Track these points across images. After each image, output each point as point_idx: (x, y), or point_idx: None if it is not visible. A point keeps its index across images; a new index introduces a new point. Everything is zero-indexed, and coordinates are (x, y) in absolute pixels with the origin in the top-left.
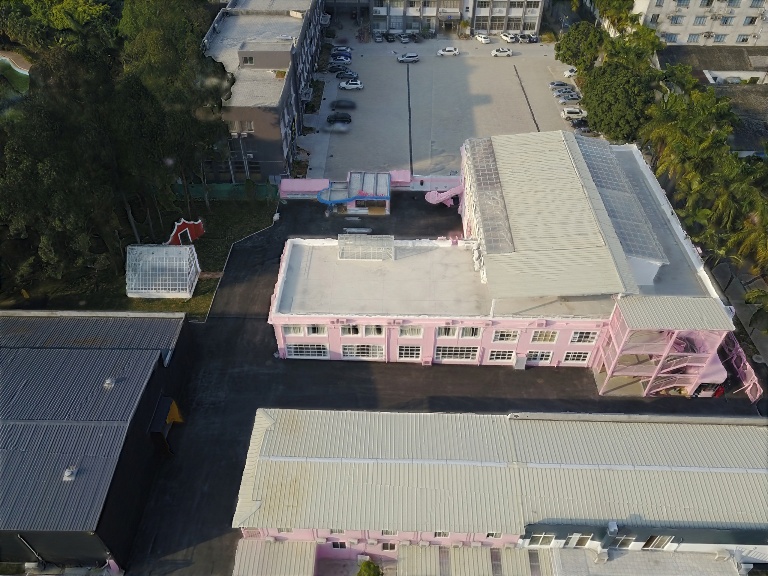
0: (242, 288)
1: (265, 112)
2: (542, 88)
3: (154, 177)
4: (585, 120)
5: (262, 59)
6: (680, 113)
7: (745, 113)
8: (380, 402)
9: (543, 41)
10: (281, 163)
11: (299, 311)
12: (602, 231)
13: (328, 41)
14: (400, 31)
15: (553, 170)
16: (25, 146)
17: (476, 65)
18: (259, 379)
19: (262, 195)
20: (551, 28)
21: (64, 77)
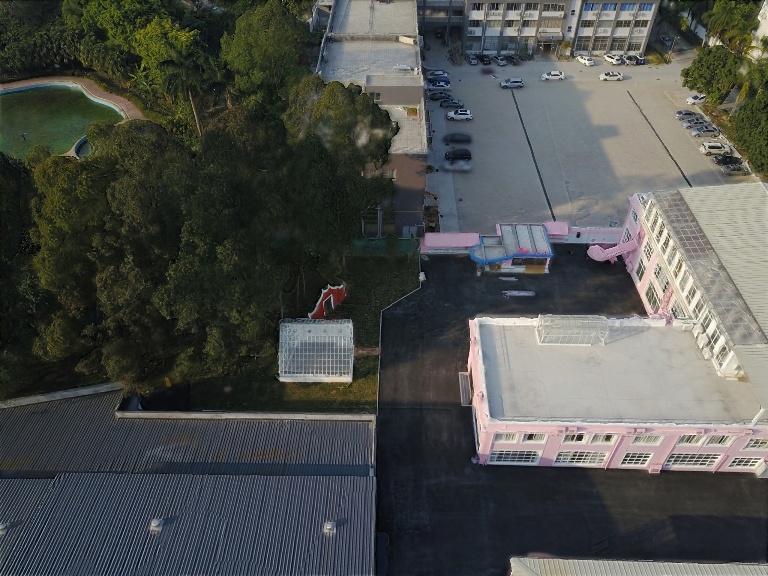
0: (408, 369)
1: (412, 159)
2: (667, 117)
3: (330, 251)
4: (730, 156)
5: (391, 95)
6: None
7: None
8: (614, 524)
9: (651, 63)
10: (420, 213)
11: (515, 415)
12: None
13: None
14: (494, 52)
15: None
16: (204, 226)
17: (587, 91)
18: (463, 494)
19: (401, 250)
20: (654, 48)
21: (249, 143)
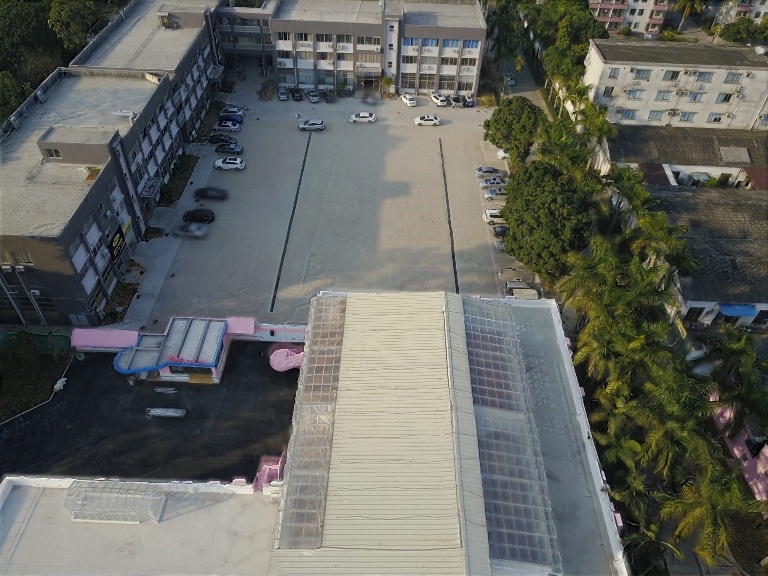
0: None
1: (42, 243)
2: (468, 174)
3: None
4: None
5: (72, 152)
6: (608, 280)
7: (709, 235)
8: None
9: (480, 105)
10: (81, 301)
11: None
12: (462, 512)
13: (221, 97)
14: (311, 86)
15: (417, 370)
16: None
17: (393, 137)
18: None
19: (49, 347)
20: (493, 87)
21: None
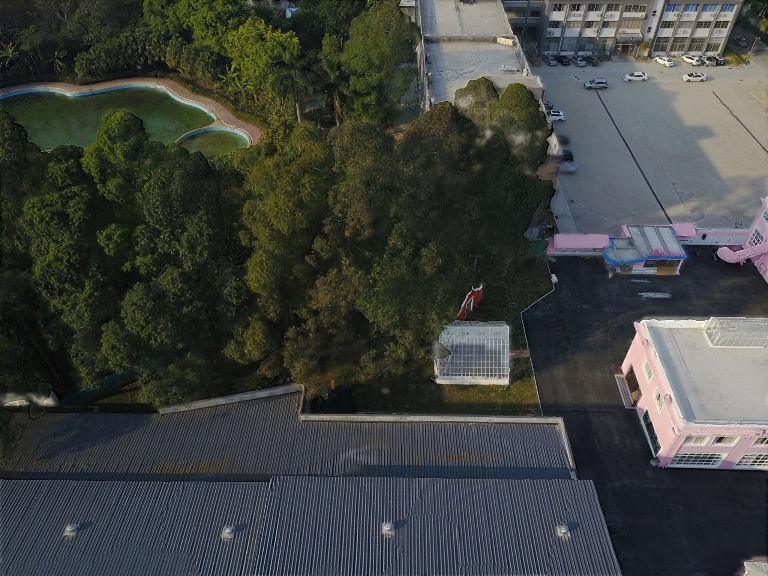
0: (562, 371)
1: (546, 161)
2: (758, 118)
3: (509, 254)
4: None
5: None
6: None
7: None
8: None
9: (730, 64)
10: None
11: (706, 418)
12: None
13: None
14: (571, 53)
15: None
16: (411, 229)
17: (672, 92)
18: (650, 497)
19: (528, 252)
20: None
21: (454, 145)
